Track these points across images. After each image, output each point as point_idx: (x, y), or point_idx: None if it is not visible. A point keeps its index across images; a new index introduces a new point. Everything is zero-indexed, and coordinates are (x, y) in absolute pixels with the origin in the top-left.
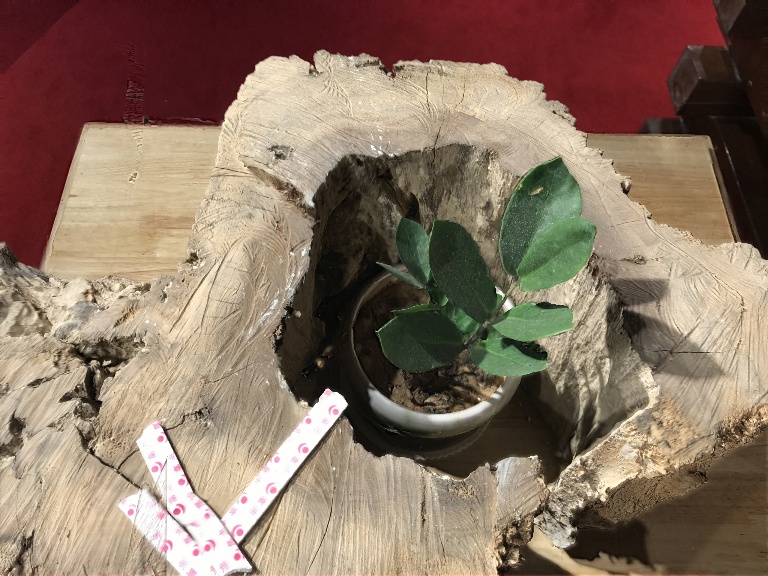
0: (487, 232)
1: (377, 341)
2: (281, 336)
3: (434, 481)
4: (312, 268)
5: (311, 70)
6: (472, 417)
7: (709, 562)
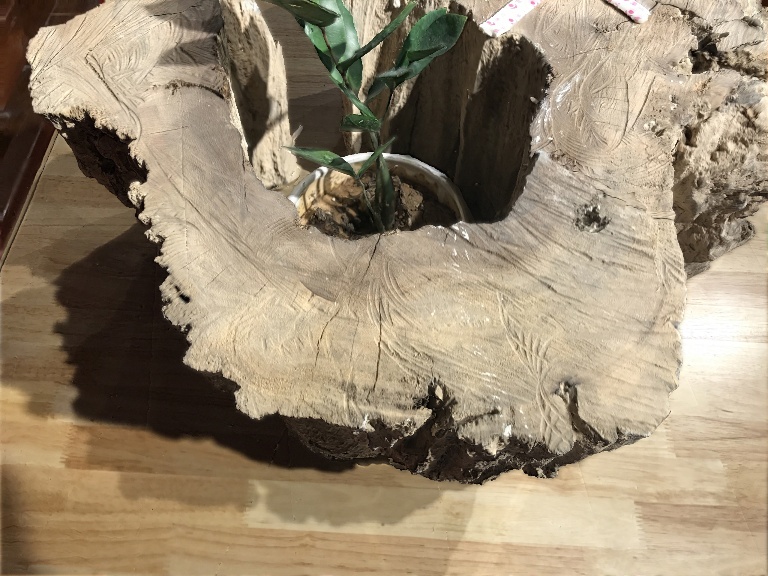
0: None
1: None
2: None
3: None
4: None
5: (574, 406)
6: None
7: None
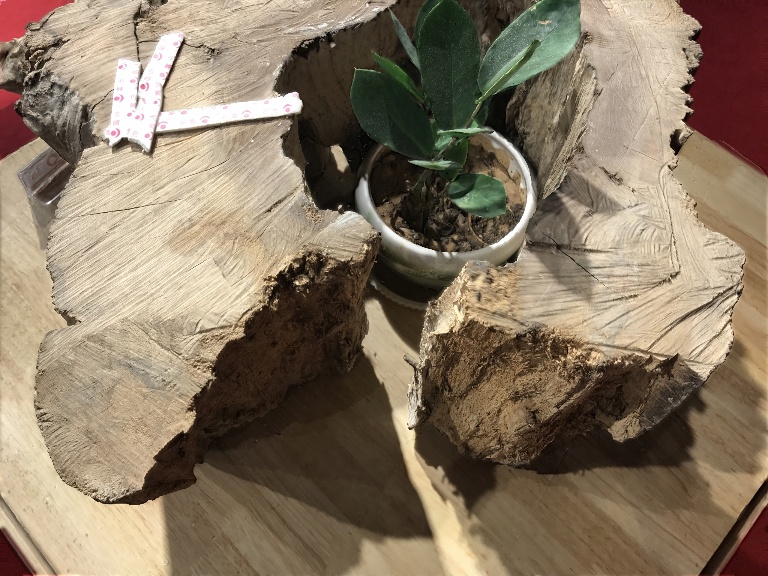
0: (554, 131)
1: (410, 166)
2: (307, 47)
3: (300, 194)
4: (380, 36)
5: None
6: (415, 253)
7: (520, 557)
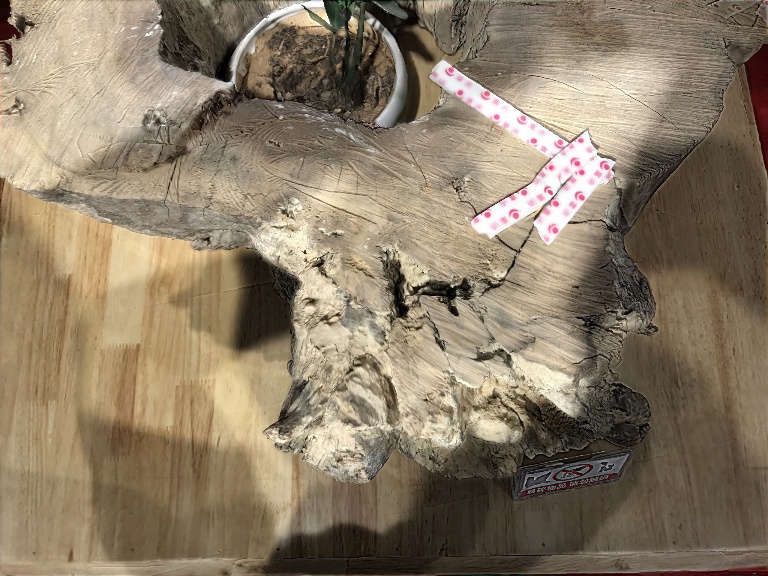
0: None
1: None
2: None
3: None
4: None
5: None
6: None
7: None
